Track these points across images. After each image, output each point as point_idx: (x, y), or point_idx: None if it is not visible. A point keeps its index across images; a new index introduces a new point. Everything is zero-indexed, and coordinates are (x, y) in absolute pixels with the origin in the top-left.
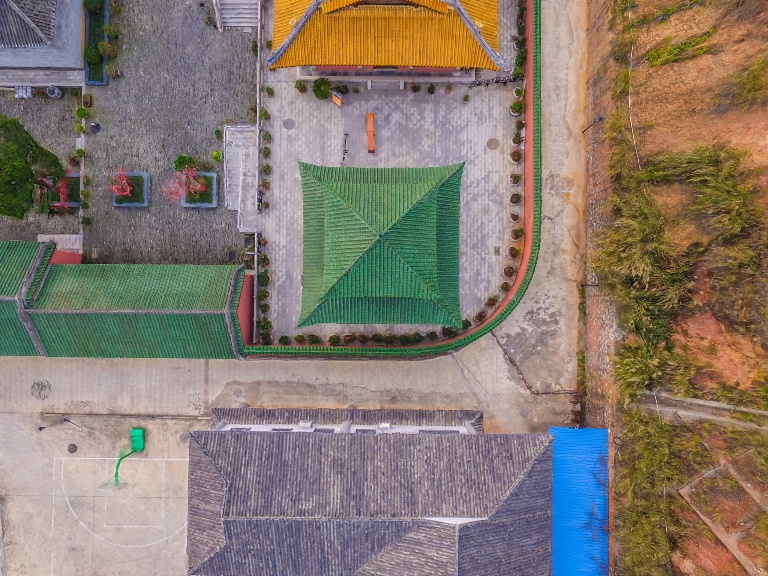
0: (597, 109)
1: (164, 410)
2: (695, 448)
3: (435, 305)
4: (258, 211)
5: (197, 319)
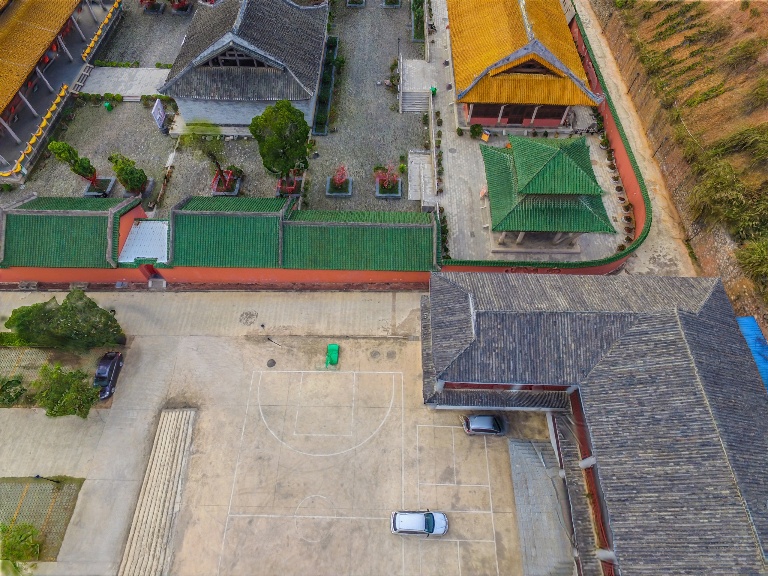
0: (660, 139)
1: (356, 332)
2: None
3: (593, 216)
4: (436, 193)
5: (410, 233)
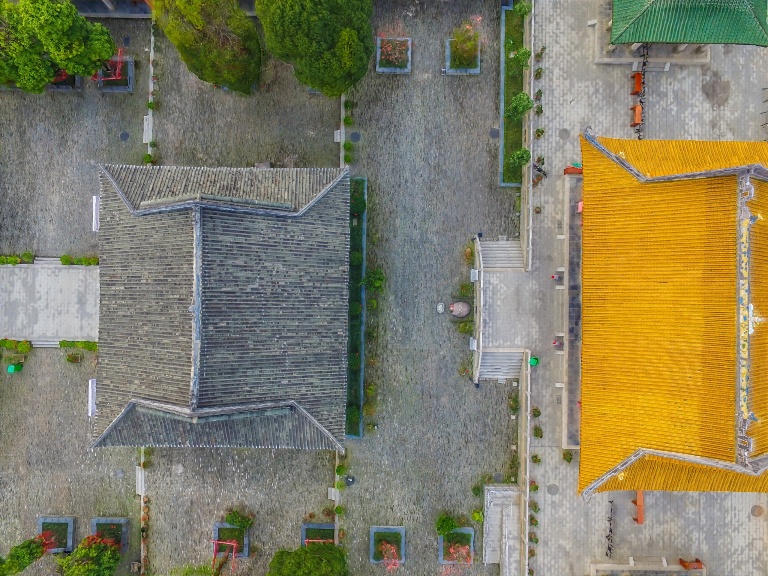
0: None
1: None
2: None
3: None
4: None
5: None
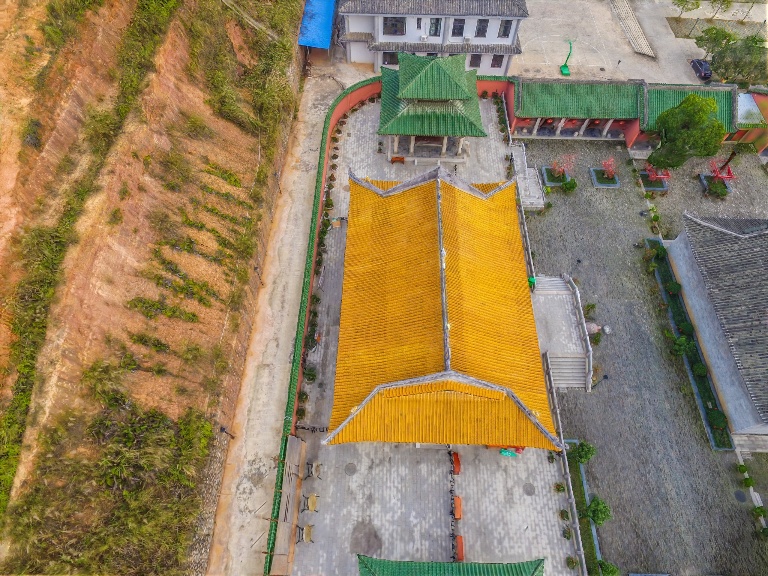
0: None
1: None
2: (263, 11)
3: None
4: None
5: None
